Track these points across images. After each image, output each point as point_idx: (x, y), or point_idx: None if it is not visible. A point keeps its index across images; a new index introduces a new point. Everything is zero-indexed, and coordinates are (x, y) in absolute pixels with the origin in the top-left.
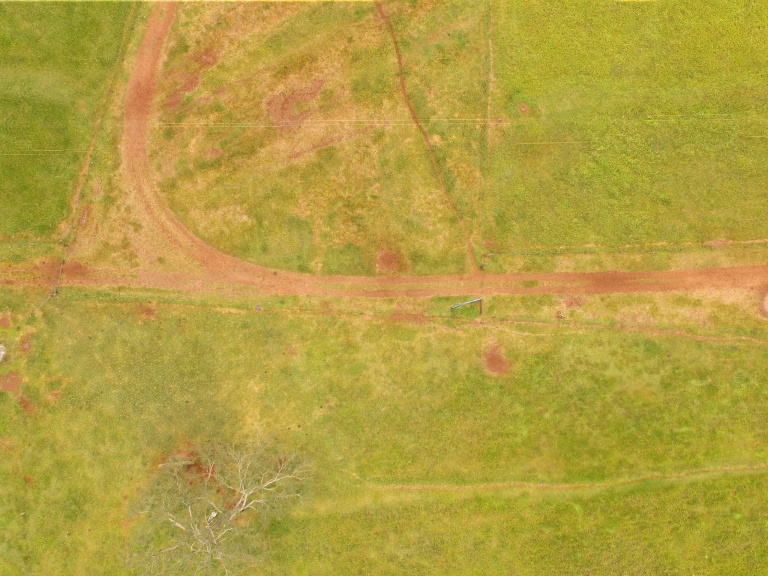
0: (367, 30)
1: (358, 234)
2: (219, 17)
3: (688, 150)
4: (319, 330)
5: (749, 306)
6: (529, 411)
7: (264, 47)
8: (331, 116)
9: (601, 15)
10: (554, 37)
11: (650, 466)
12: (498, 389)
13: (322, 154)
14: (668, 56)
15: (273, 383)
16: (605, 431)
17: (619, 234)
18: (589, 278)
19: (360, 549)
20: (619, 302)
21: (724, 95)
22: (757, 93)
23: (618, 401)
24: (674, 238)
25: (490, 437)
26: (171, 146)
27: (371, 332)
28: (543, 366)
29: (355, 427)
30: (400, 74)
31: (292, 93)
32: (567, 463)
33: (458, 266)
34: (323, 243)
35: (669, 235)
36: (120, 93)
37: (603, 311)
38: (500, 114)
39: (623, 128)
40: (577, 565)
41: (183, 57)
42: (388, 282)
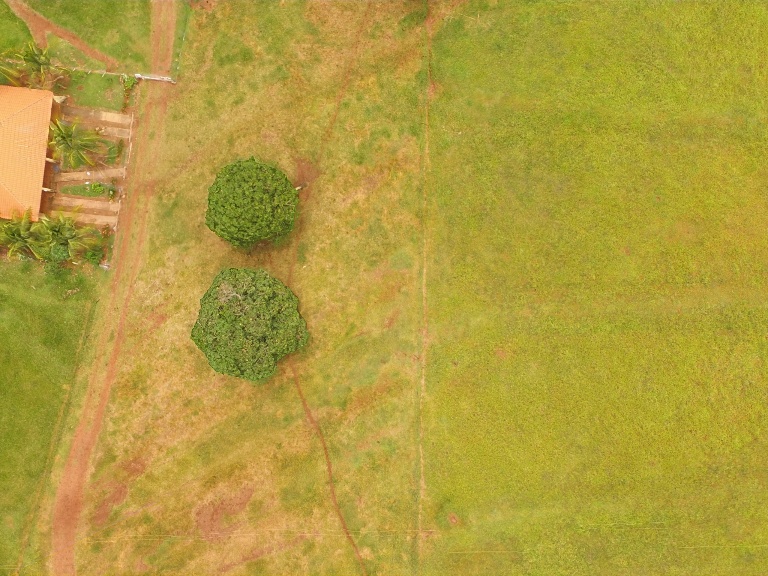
0: (297, 435)
1: None
2: (147, 426)
3: (621, 561)
4: None
5: None
6: None
7: (193, 455)
8: (261, 525)
9: (532, 419)
10: (485, 443)
11: None
12: None
13: (252, 568)
14: (600, 462)
15: None
16: None
17: None
18: None
19: None
20: None
21: (656, 505)
22: (690, 502)
23: None
24: None
25: None
26: (100, 559)
27: None
28: None
29: None
30: (330, 482)
31: (221, 503)
32: None
33: None
34: None
35: None
36: (47, 508)
37: None
38: (431, 525)
39: (555, 539)
40: None
41: (111, 466)
42: None
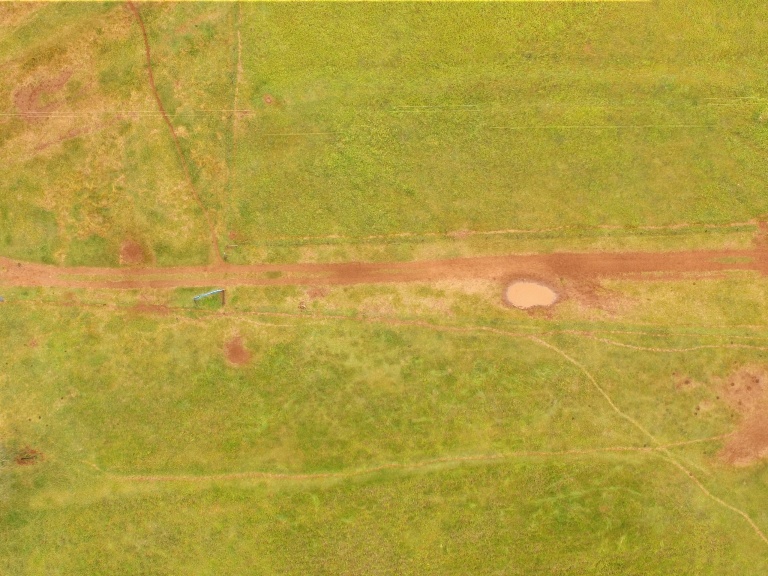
0: (117, 22)
1: (104, 225)
2: None
3: (432, 141)
4: (61, 321)
5: (491, 296)
6: (269, 402)
7: (13, 39)
8: (79, 107)
9: (349, 6)
10: (301, 28)
11: (389, 456)
12: (238, 380)
13: (68, 145)
14: (414, 47)
15: (14, 374)
16: (344, 421)
17: (362, 225)
18: (333, 269)
19: (97, 540)
20: (362, 293)
21: (468, 86)
22: (501, 84)
23: (357, 391)
24: (417, 229)
25: (229, 428)
26: None
27: (113, 323)
28: (283, 357)
29: (95, 418)
30: (148, 65)
31: (40, 85)
32: (305, 453)
33: (202, 257)
34: (68, 234)
35: (412, 226)
36: None
37: (346, 302)
38: (246, 105)
39: (368, 119)
40: (312, 555)
41: None
42: (132, 273)
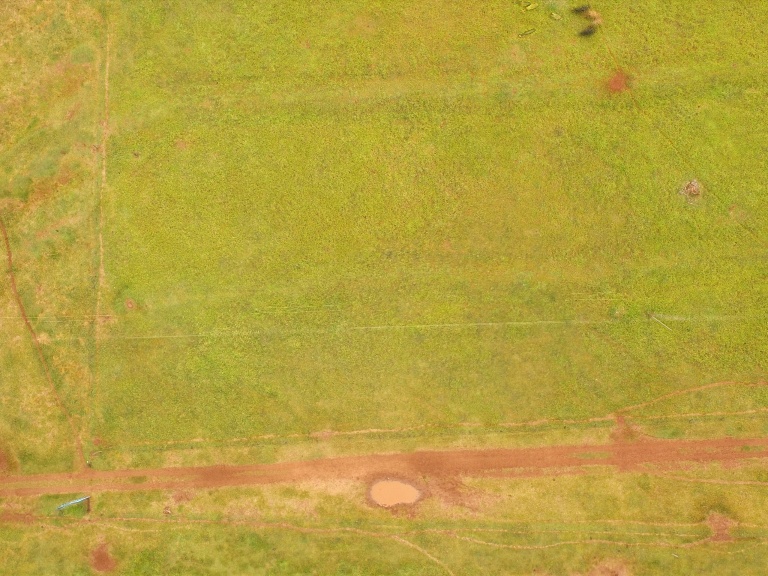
0: None
1: None
2: None
3: (294, 342)
4: None
5: (355, 496)
6: None
7: None
8: None
9: (210, 207)
10: (163, 231)
11: None
12: None
13: None
14: (275, 248)
15: None
16: None
17: (226, 428)
18: (198, 472)
19: None
20: (226, 496)
21: (328, 287)
22: (361, 284)
23: None
24: (280, 431)
25: None
26: None
27: None
28: (148, 564)
29: None
30: (10, 271)
31: None
32: None
33: (67, 464)
34: None
35: (276, 428)
36: None
37: (211, 505)
38: (108, 310)
39: (229, 322)
40: None
41: None
42: None
